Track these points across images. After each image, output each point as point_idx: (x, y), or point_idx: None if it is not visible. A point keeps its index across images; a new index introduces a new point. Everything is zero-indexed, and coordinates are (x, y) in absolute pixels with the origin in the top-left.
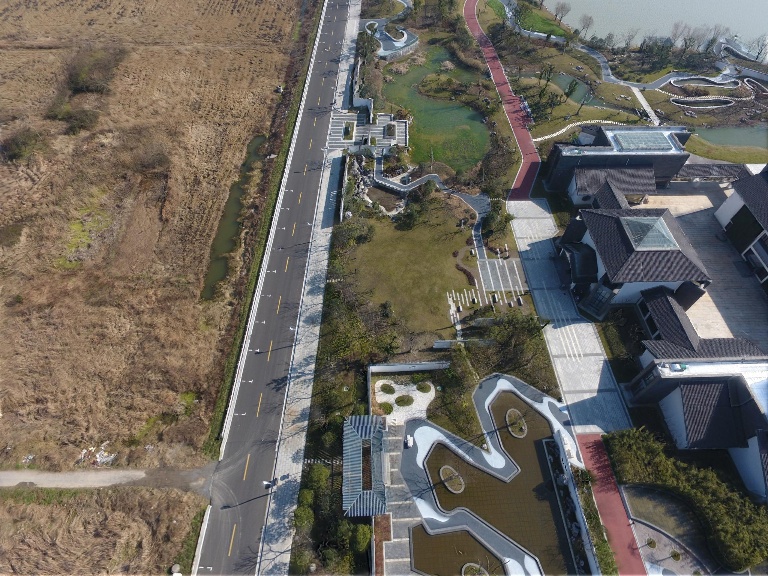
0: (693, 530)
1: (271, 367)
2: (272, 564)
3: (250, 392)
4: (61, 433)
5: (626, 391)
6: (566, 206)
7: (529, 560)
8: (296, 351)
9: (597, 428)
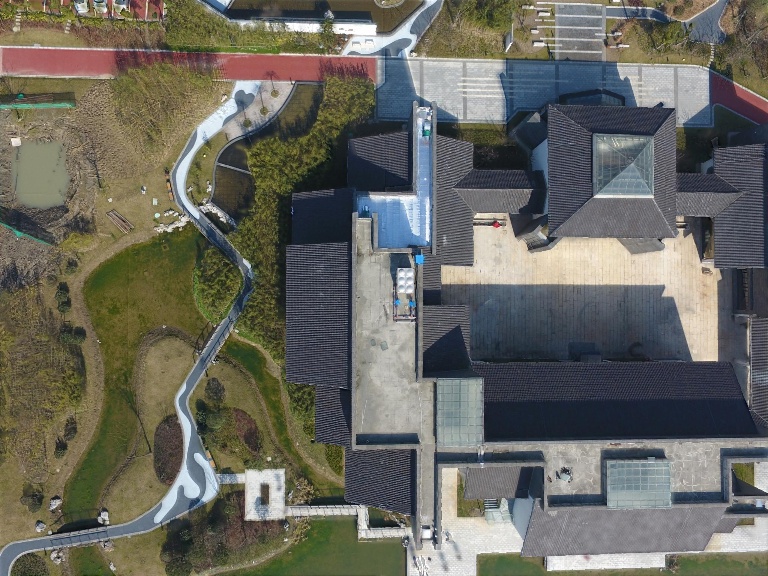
0: (283, 136)
1: None
2: None
3: None
4: None
5: None
6: (698, 148)
7: None
8: None
9: (381, 82)
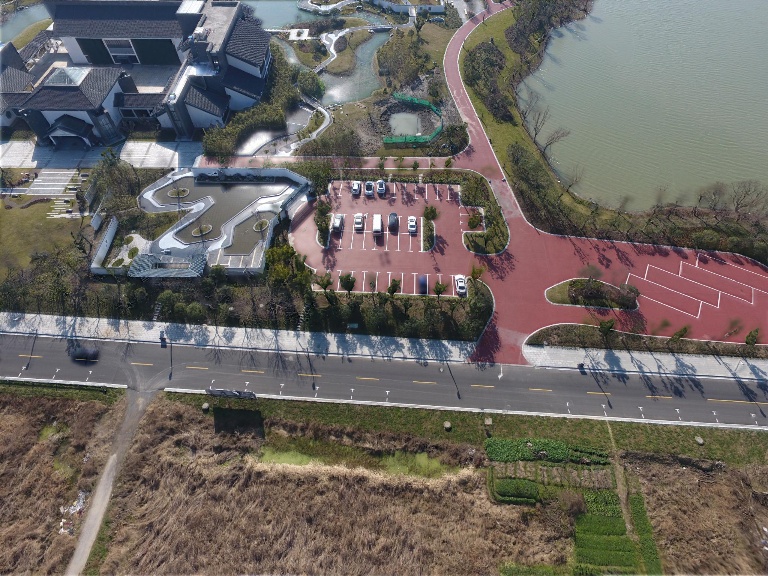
0: (266, 135)
1: (51, 353)
2: (223, 338)
3: (69, 369)
4: (24, 569)
5: (182, 139)
6: (8, 130)
7: (260, 201)
8: (44, 332)
9: (199, 157)
